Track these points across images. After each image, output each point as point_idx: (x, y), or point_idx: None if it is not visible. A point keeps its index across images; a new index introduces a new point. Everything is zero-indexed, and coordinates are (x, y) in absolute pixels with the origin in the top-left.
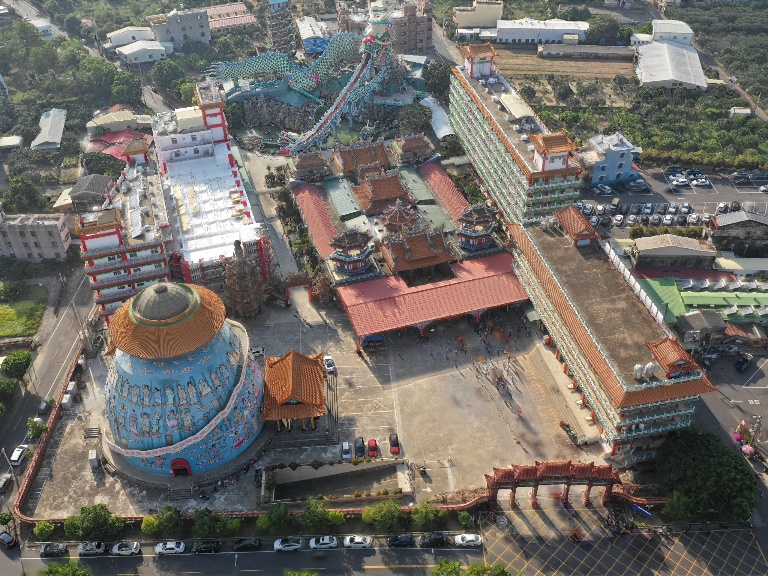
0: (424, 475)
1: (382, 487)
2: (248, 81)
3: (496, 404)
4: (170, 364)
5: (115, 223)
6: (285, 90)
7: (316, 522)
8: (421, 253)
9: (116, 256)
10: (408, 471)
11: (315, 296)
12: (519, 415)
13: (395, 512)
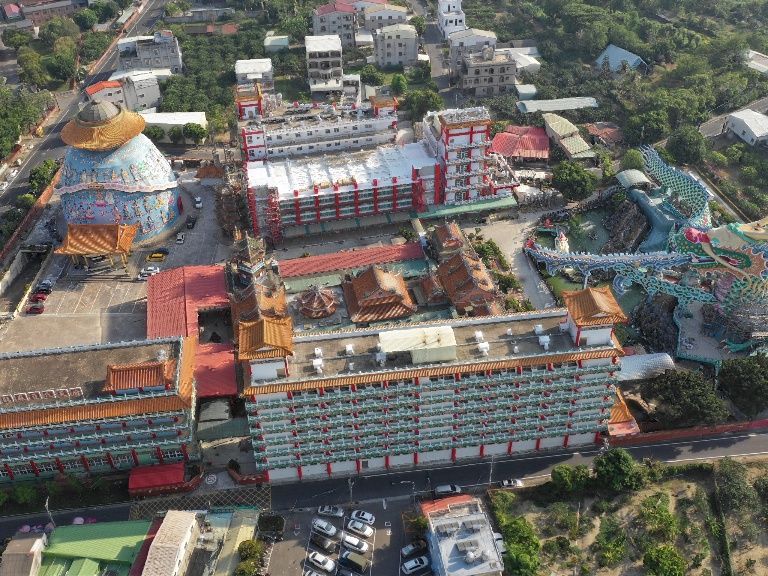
0: None
1: (3, 305)
2: None
3: None
4: None
5: None
6: (666, 227)
7: None
8: (241, 311)
9: None
10: (5, 317)
11: None
12: None
13: None
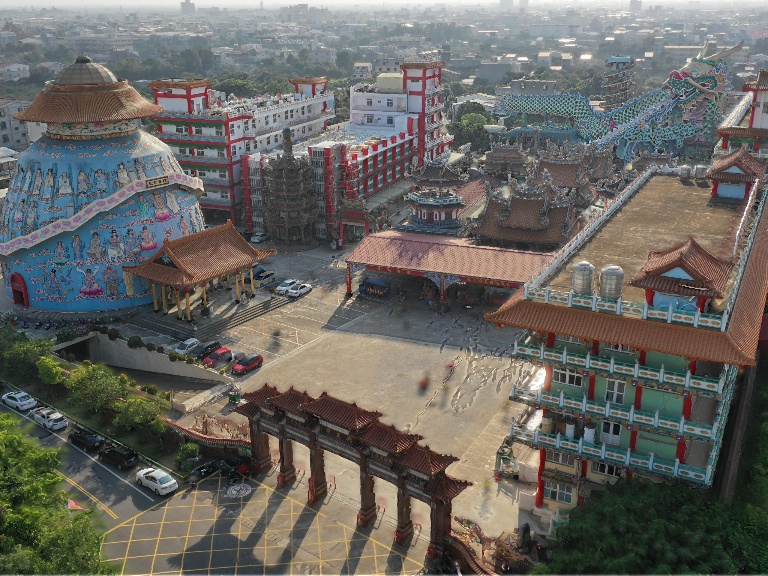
0: (231, 404)
1: None
2: None
3: (441, 386)
4: (49, 146)
5: (186, 83)
6: (571, 135)
7: (21, 361)
8: (523, 220)
9: (184, 128)
10: (220, 392)
11: None
12: (456, 408)
13: (96, 383)
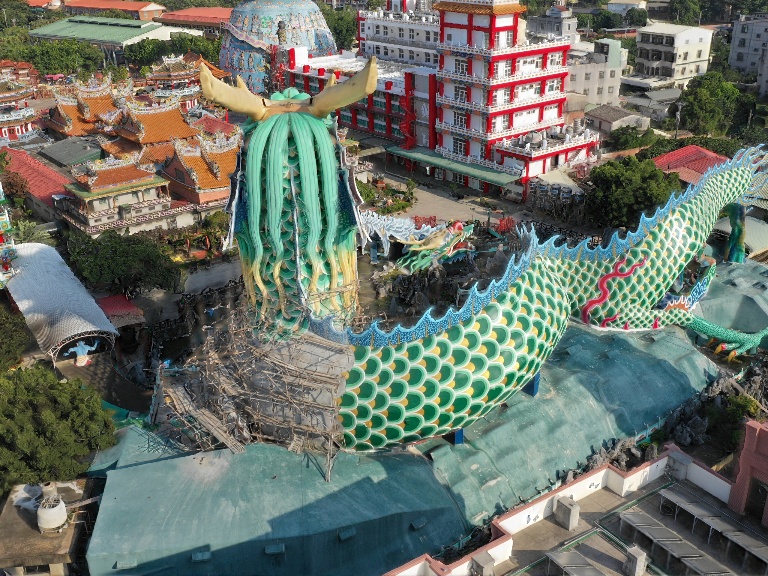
0: None
1: None
2: (745, 280)
3: None
4: None
5: None
6: None
7: None
8: None
9: None
10: None
11: None
12: None
13: None
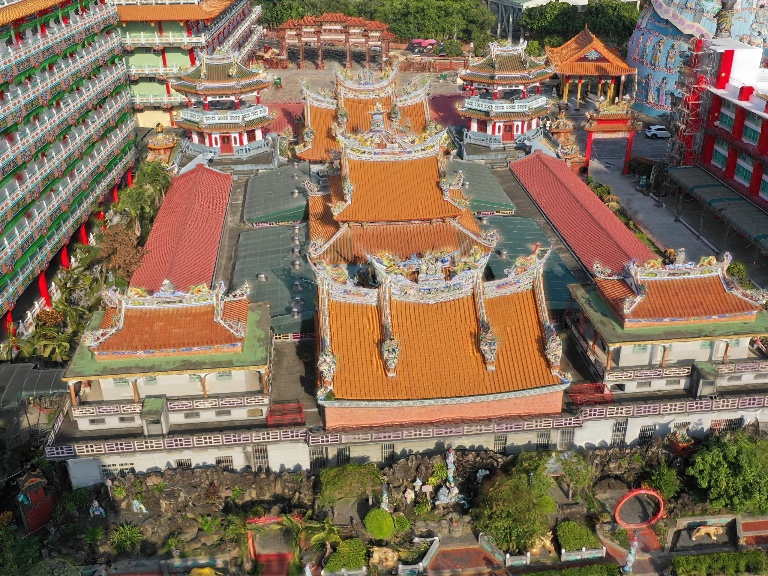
0: None
1: None
2: None
3: None
4: None
5: None
6: None
7: None
8: None
9: None
10: None
11: (578, 165)
12: None
13: None
